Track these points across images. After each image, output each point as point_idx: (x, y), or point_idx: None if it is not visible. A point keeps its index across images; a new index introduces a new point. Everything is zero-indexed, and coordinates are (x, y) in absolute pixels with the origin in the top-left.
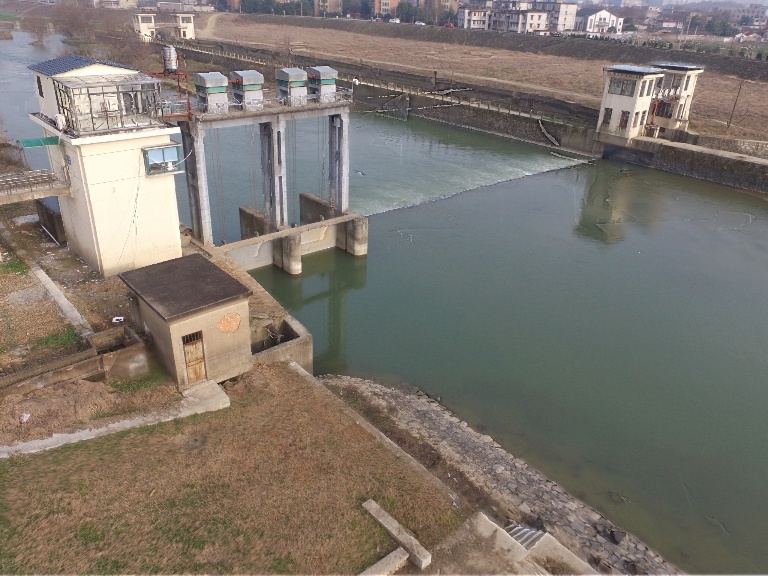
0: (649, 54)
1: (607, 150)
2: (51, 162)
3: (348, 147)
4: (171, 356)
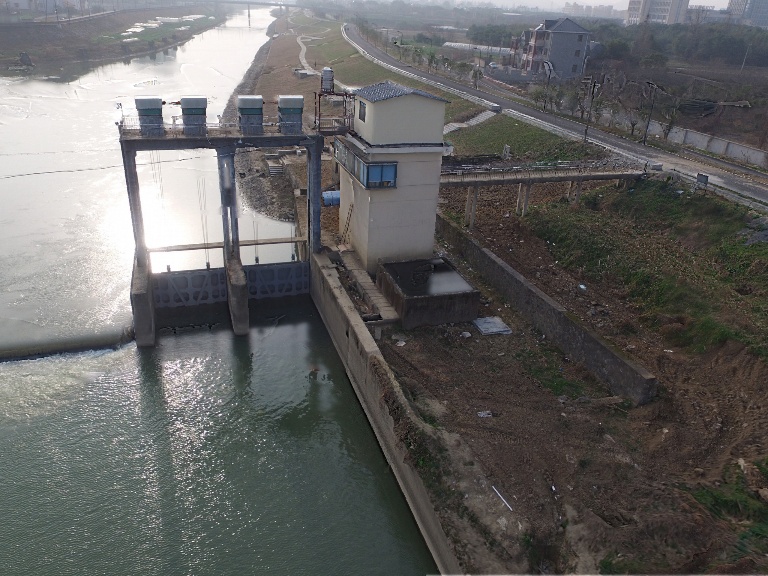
0: None
1: None
2: None
3: None
4: None
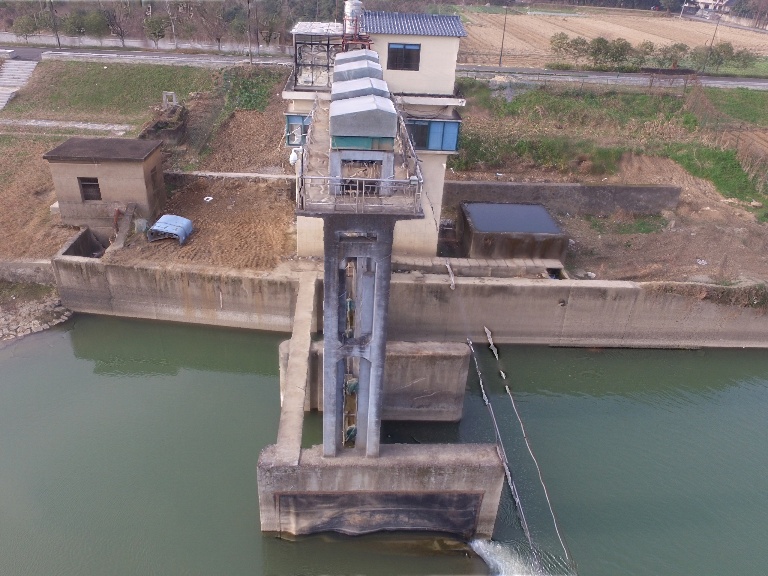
0: None
1: None
2: None
3: (326, 323)
4: None
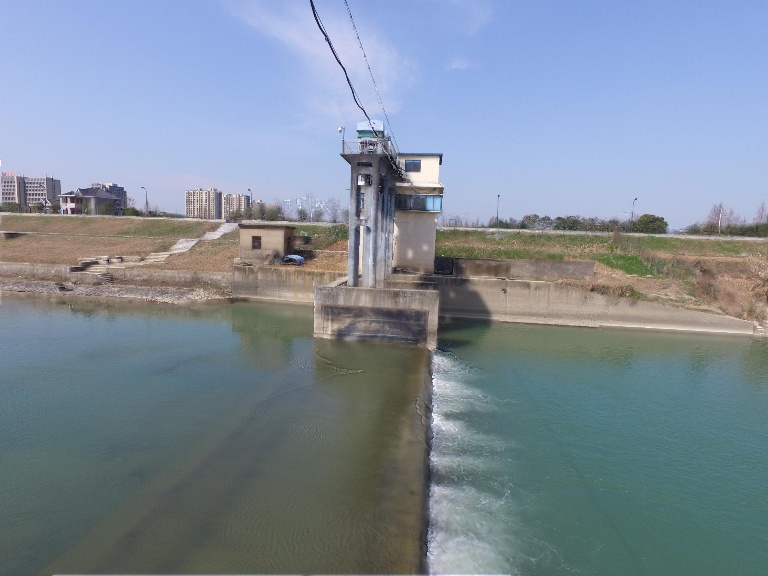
0: None
1: None
2: None
3: (351, 208)
4: None
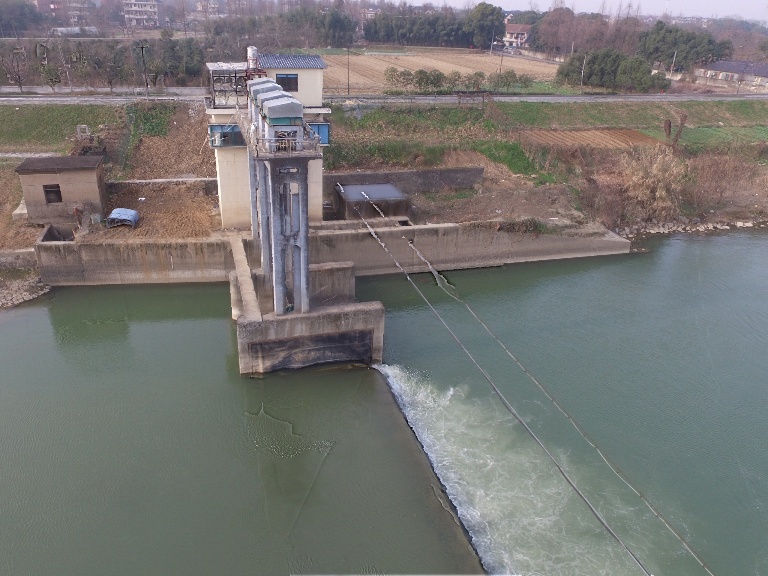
0: None
1: None
2: None
3: (274, 225)
4: None
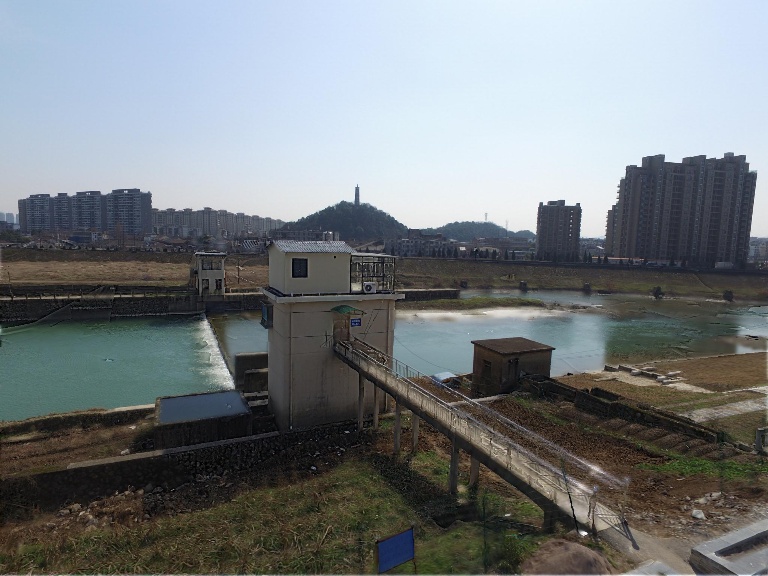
0: (63, 254)
1: (208, 306)
2: (292, 342)
3: None
4: (547, 373)
